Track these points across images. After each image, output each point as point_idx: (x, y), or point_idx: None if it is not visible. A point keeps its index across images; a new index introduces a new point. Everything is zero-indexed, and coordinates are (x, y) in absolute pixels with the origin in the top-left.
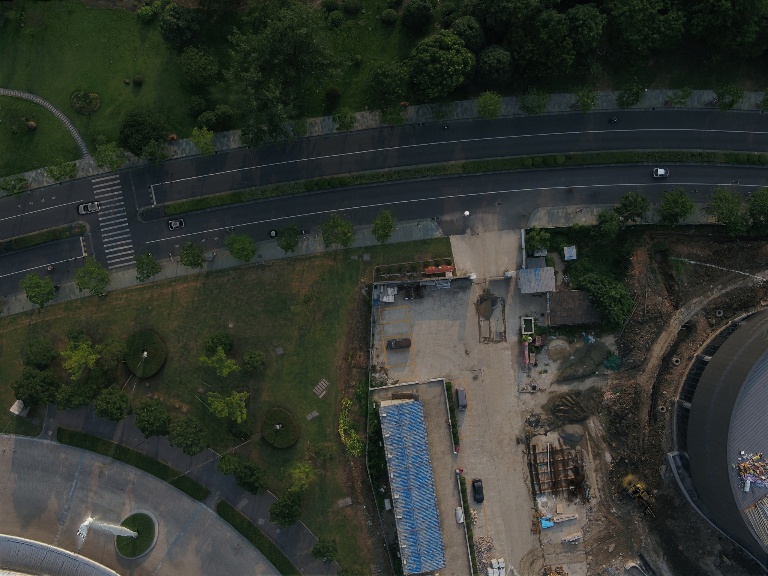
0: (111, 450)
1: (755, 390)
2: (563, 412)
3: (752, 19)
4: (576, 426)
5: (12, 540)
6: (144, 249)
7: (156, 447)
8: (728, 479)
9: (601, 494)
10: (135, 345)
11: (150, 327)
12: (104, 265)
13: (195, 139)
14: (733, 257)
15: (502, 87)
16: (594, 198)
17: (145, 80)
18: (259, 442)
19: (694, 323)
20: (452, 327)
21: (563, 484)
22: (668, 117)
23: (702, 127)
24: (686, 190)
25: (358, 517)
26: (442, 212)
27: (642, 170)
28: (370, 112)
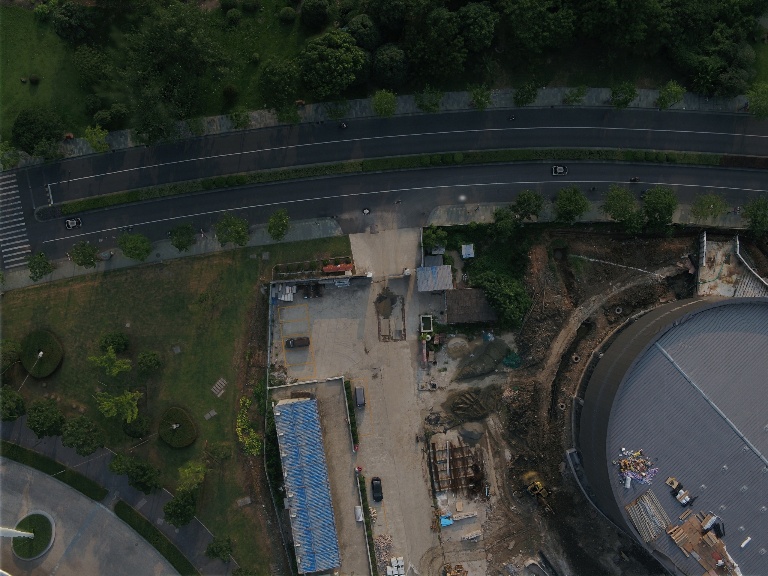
0: (7, 451)
1: (635, 387)
2: (463, 410)
3: (639, 17)
4: (475, 424)
5: None
6: (41, 248)
7: (53, 447)
8: (608, 476)
9: (501, 492)
10: (31, 345)
11: (47, 327)
12: (0, 265)
13: (88, 138)
14: (632, 254)
15: (399, 85)
16: (493, 196)
17: (42, 79)
18: (157, 442)
19: (593, 320)
20: (351, 325)
21: (463, 482)
22: (566, 115)
23: (600, 125)
24: (584, 188)
25: (257, 516)
26: (341, 210)
27: (541, 168)
28: (268, 110)
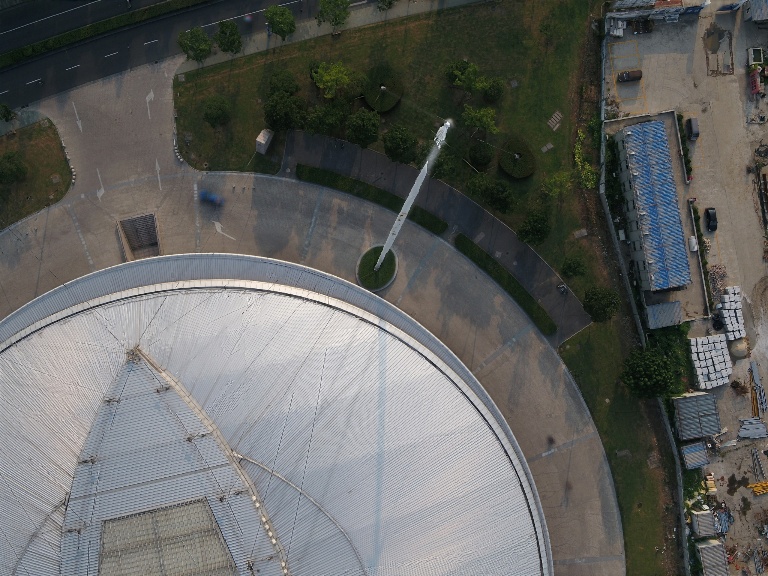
0: (350, 185)
1: None
2: None
3: None
4: None
5: (268, 261)
6: None
7: (393, 183)
8: None
9: None
10: (373, 79)
11: (385, 64)
12: None
13: None
14: None
15: None
16: None
17: None
18: (495, 175)
19: None
20: (680, 60)
21: None
22: None
23: None
24: None
25: (593, 248)
26: None
27: None
28: None
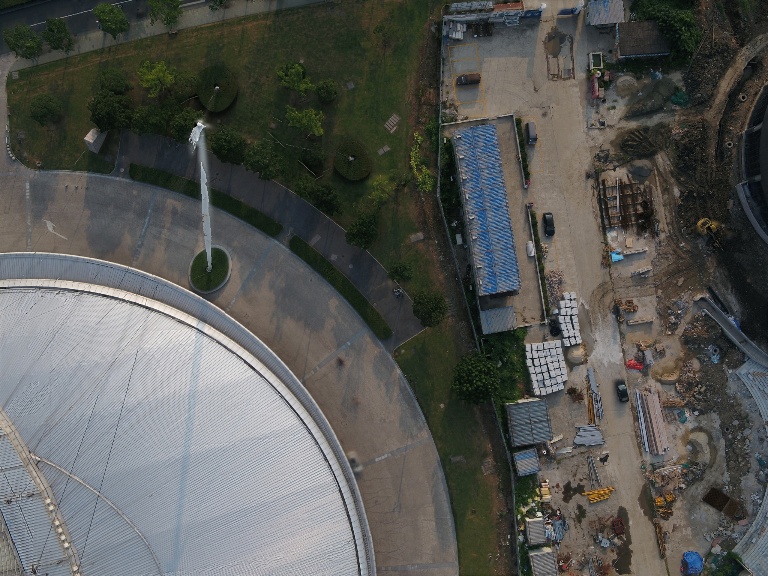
0: (184, 186)
1: None
2: (631, 147)
3: None
4: (645, 161)
5: (90, 261)
6: None
7: (228, 184)
8: None
9: (670, 228)
10: (207, 79)
11: (221, 64)
12: None
13: None
14: None
15: None
16: None
17: None
18: (331, 177)
19: (760, 59)
20: (521, 64)
21: (632, 218)
22: None
23: None
24: None
25: (430, 252)
26: None
27: None
28: None
